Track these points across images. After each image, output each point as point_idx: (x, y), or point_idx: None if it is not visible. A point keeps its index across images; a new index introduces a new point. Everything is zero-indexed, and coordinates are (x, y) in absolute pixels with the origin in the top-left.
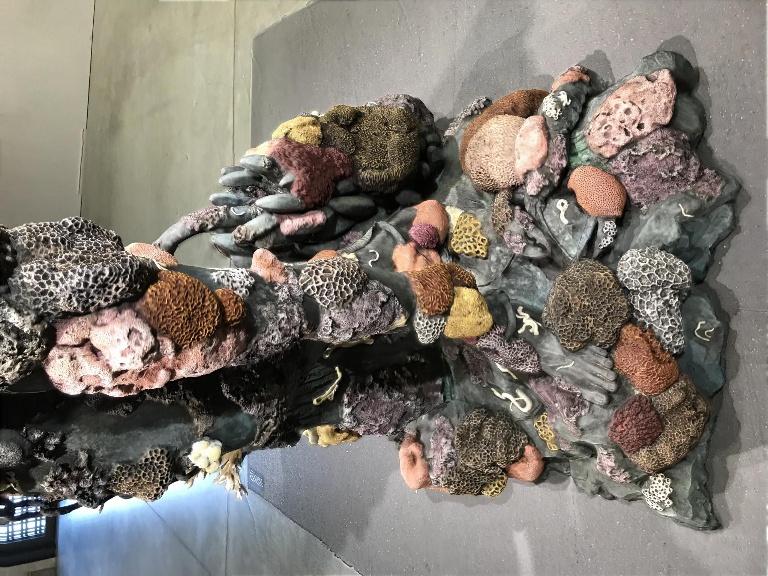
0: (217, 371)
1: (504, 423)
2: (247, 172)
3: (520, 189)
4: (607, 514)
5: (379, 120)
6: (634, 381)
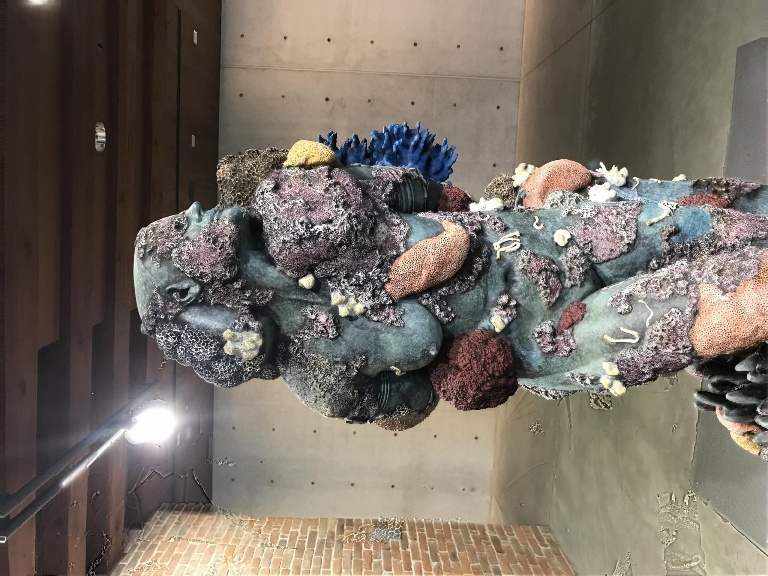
0: None
1: None
2: None
3: None
4: None
5: None
6: None
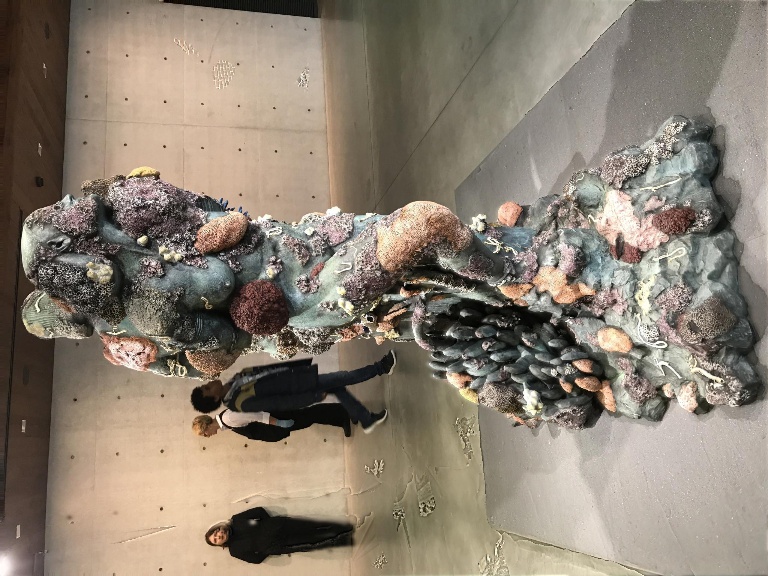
0: None
1: None
2: None
3: None
4: None
5: None
6: None
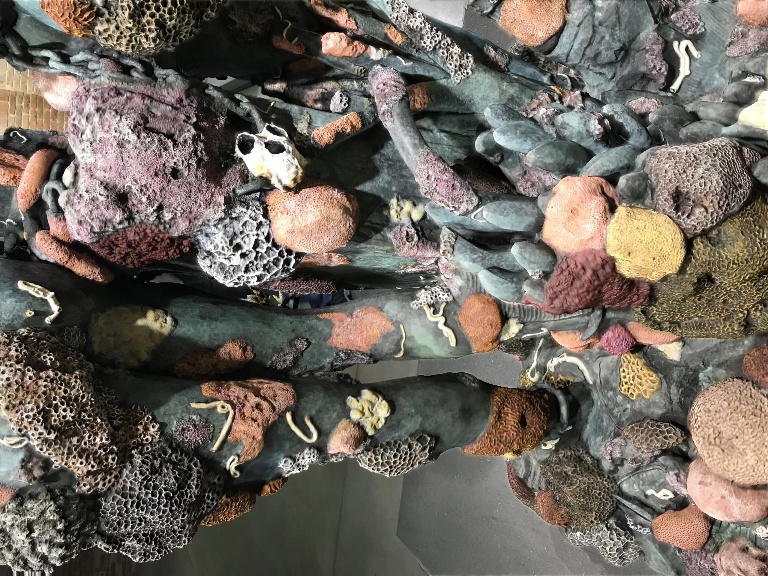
0: (284, 373)
1: (522, 347)
2: (526, 226)
3: (694, 447)
4: (516, 385)
5: (763, 295)
6: (539, 498)
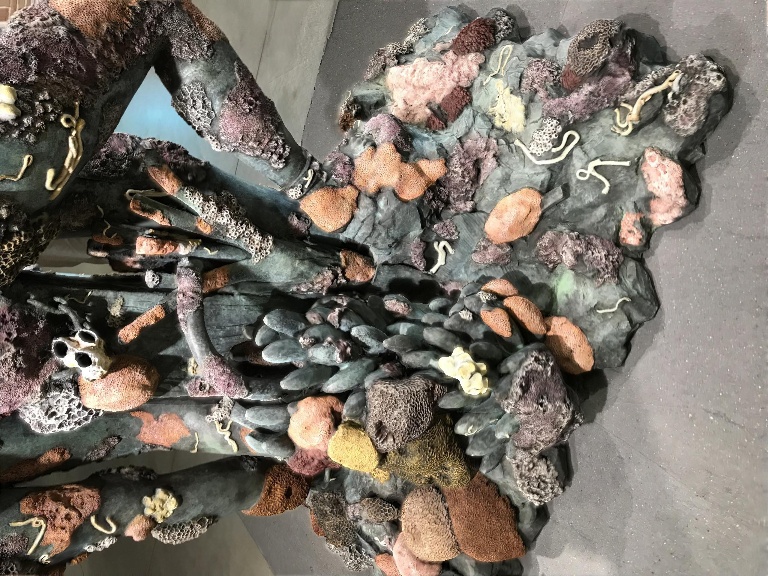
0: (98, 459)
1: None
2: (277, 424)
3: None
4: None
5: None
6: None
